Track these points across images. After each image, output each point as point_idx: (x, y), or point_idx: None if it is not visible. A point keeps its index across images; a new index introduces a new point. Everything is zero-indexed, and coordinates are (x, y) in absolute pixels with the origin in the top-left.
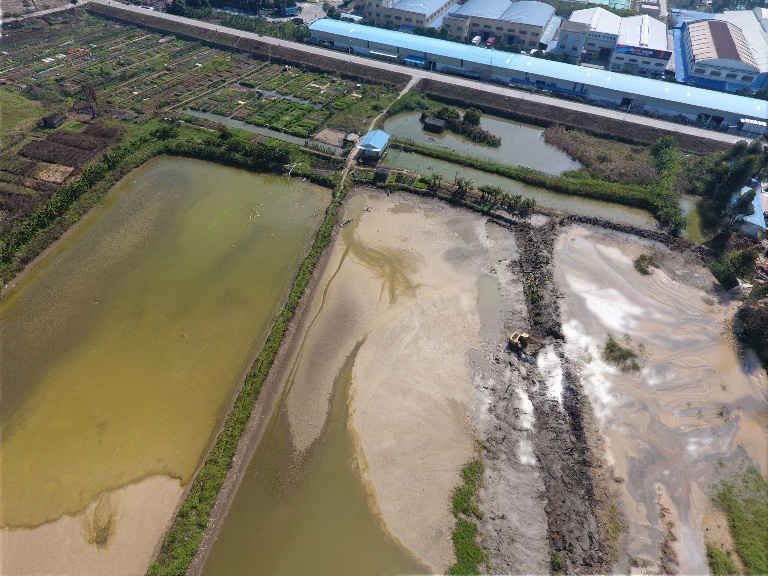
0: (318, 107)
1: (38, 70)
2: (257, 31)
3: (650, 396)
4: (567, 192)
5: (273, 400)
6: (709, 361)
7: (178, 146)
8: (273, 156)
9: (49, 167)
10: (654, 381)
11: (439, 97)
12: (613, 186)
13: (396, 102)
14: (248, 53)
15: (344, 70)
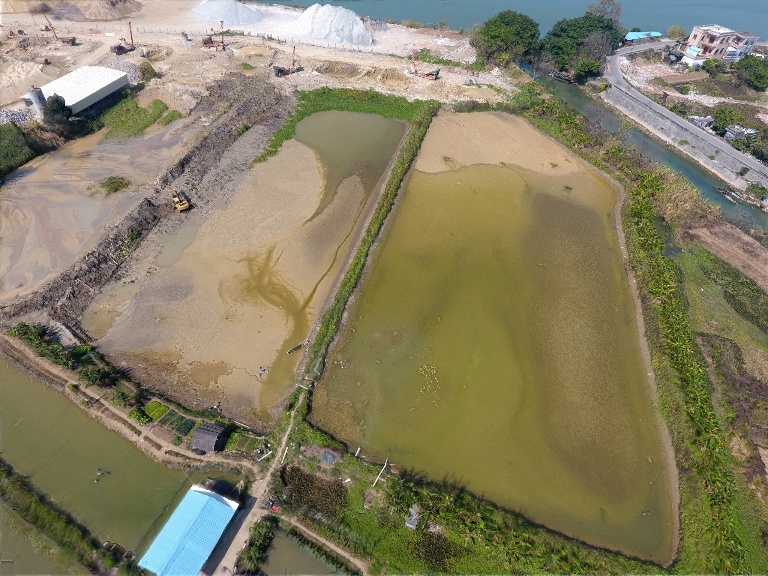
0: None
1: None
2: None
3: (122, 167)
4: None
5: (374, 195)
6: (51, 176)
7: (645, 569)
8: None
9: None
10: (108, 172)
11: None
12: None
13: None
14: None
15: None
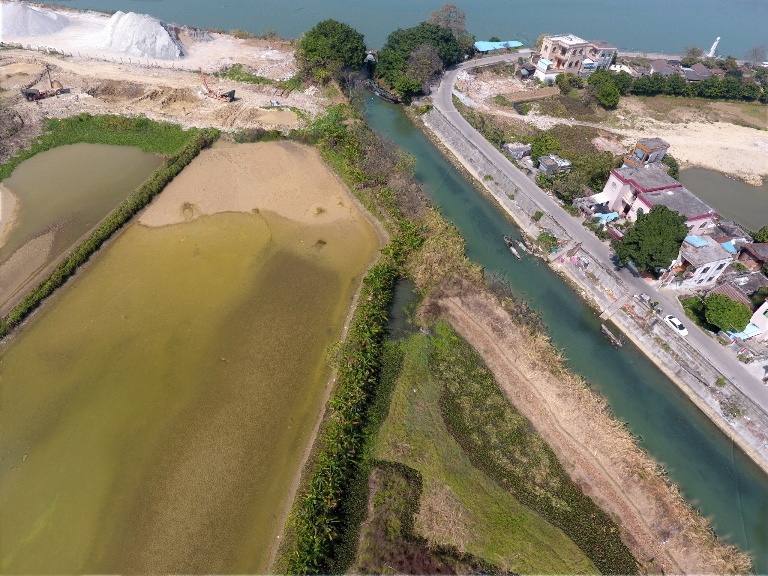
0: None
1: None
2: None
3: None
4: None
5: (56, 262)
6: None
7: None
8: None
9: None
10: None
11: None
12: None
13: None
14: None
15: None
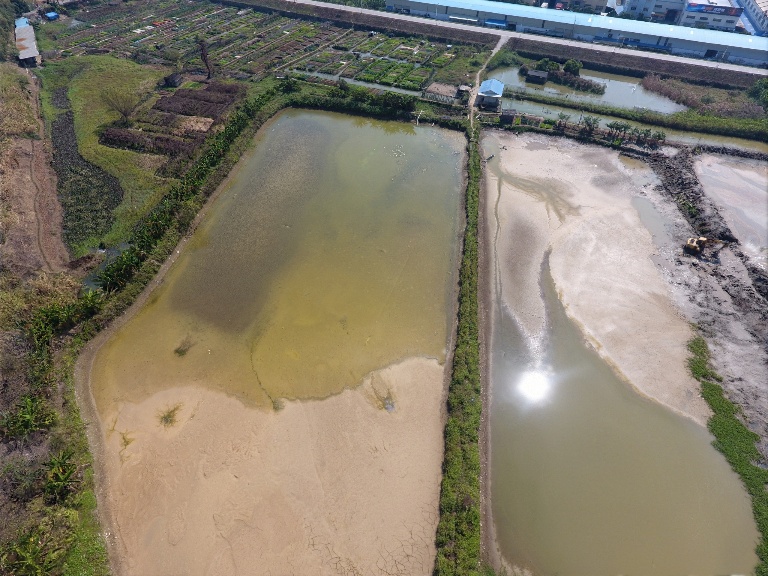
0: (417, 65)
1: (134, 39)
2: (331, 2)
3: None
4: (685, 129)
5: (490, 298)
6: None
7: (304, 98)
8: (400, 104)
9: (189, 118)
10: None
11: (530, 54)
12: (729, 121)
13: (494, 58)
14: (330, 21)
15: (431, 33)
